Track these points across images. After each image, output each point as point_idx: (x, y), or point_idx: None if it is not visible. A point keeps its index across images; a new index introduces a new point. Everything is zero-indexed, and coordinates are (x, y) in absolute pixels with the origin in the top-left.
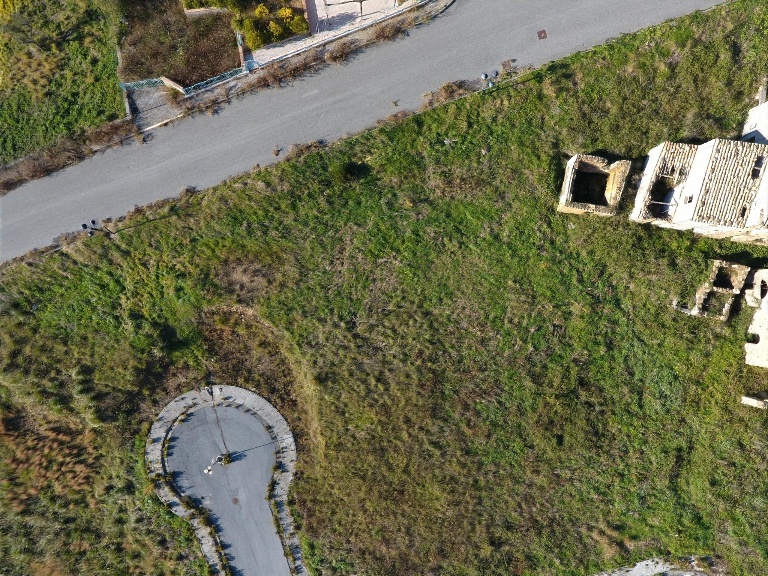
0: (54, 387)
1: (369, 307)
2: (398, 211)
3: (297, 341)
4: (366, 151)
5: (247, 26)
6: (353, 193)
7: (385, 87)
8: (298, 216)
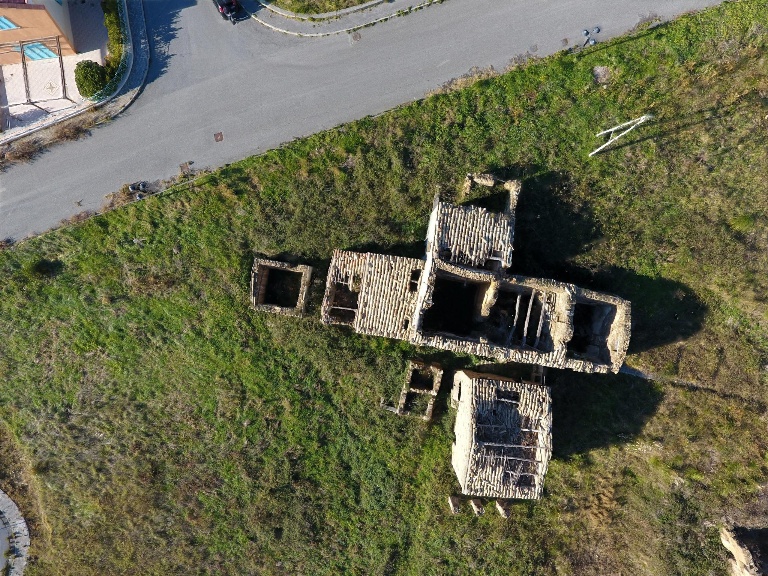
0: None
1: (82, 399)
2: (98, 307)
3: (16, 431)
4: (55, 249)
5: None
6: (52, 289)
7: (69, 187)
8: (1, 310)
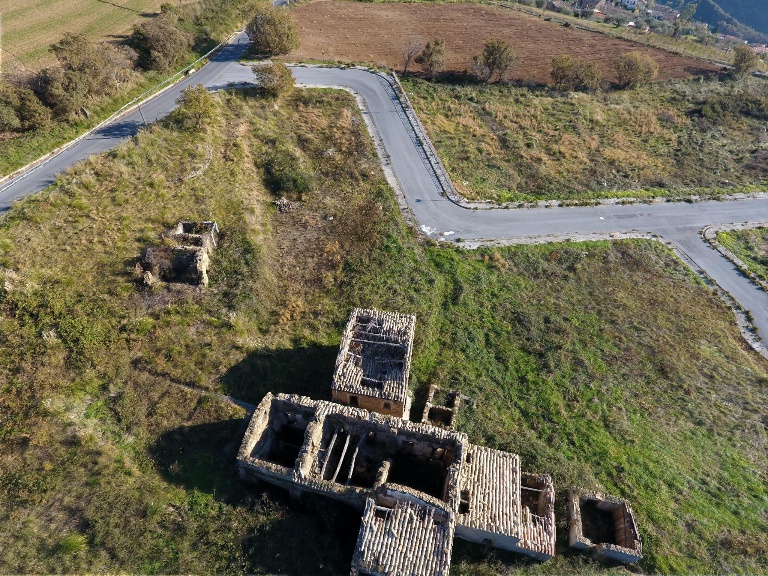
0: None
1: (759, 434)
2: None
3: None
4: None
5: None
6: None
7: None
8: None
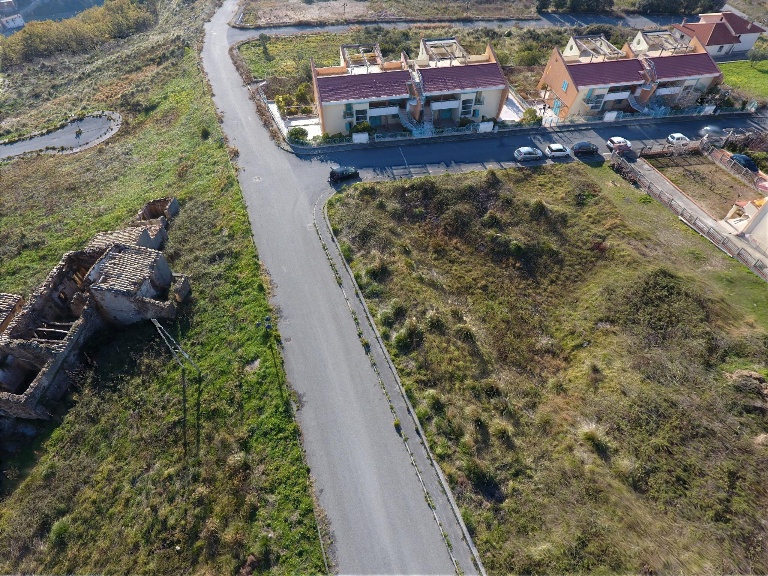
0: (144, 83)
1: None
2: None
3: None
4: None
5: (283, 96)
6: None
7: None
8: None
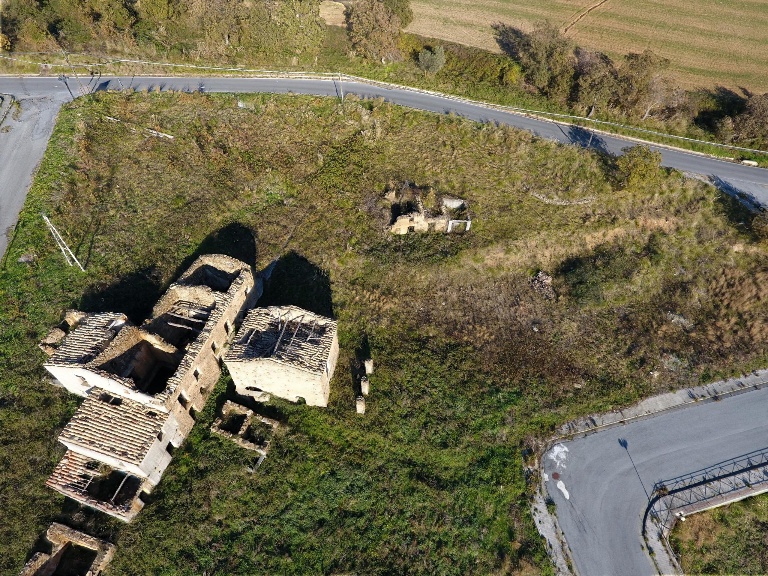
0: None
1: None
2: None
3: None
4: None
5: None
6: None
7: None
8: None
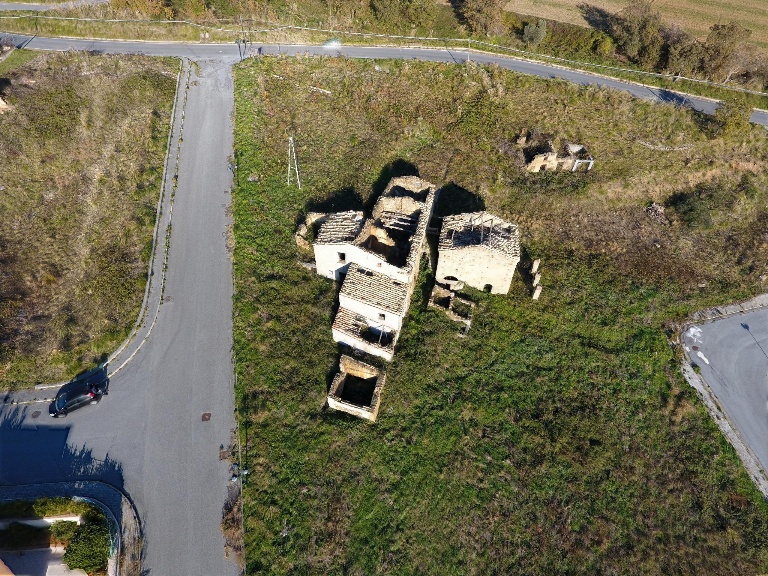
0: None
1: None
2: None
3: None
4: None
5: None
6: None
7: None
8: None
